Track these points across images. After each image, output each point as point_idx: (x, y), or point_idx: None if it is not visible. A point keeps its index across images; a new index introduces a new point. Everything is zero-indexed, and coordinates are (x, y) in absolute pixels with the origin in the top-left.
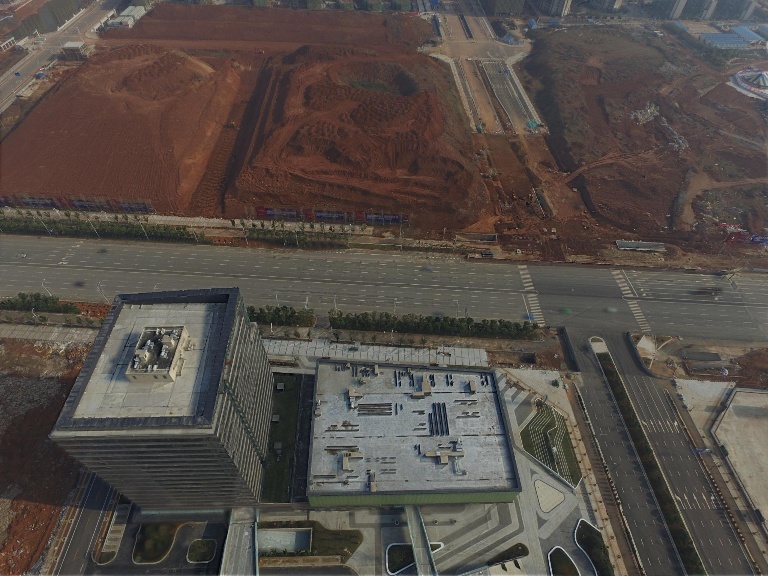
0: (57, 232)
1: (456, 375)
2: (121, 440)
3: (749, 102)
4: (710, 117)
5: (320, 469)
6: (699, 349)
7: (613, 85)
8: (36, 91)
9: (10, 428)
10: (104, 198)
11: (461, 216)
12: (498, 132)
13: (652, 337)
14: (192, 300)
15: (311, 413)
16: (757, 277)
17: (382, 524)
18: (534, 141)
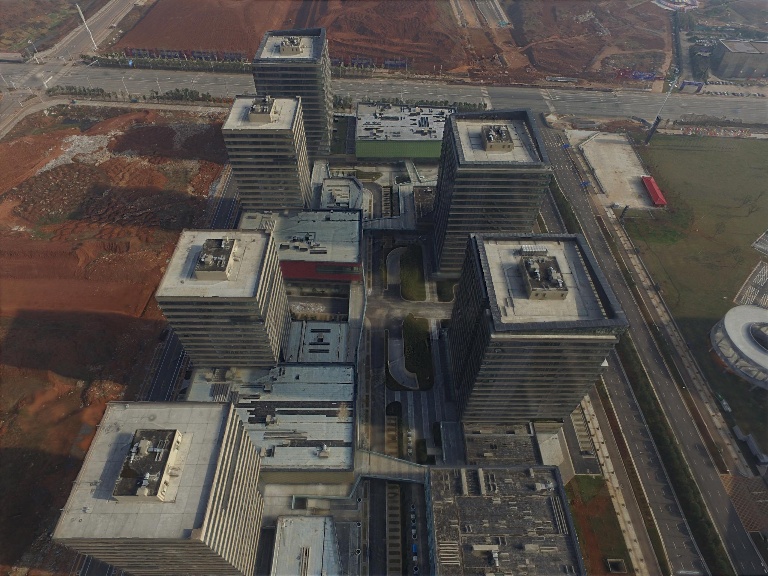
0: (187, 68)
1: (435, 109)
2: (281, 69)
3: (663, 12)
4: (631, 19)
5: (361, 135)
6: (583, 120)
7: (565, 1)
8: (146, 2)
9: (187, 140)
10: (215, 49)
11: (446, 64)
12: (477, 27)
13: (556, 115)
14: (302, 34)
15: (354, 129)
16: (631, 93)
17: (393, 171)
18: (502, 32)
